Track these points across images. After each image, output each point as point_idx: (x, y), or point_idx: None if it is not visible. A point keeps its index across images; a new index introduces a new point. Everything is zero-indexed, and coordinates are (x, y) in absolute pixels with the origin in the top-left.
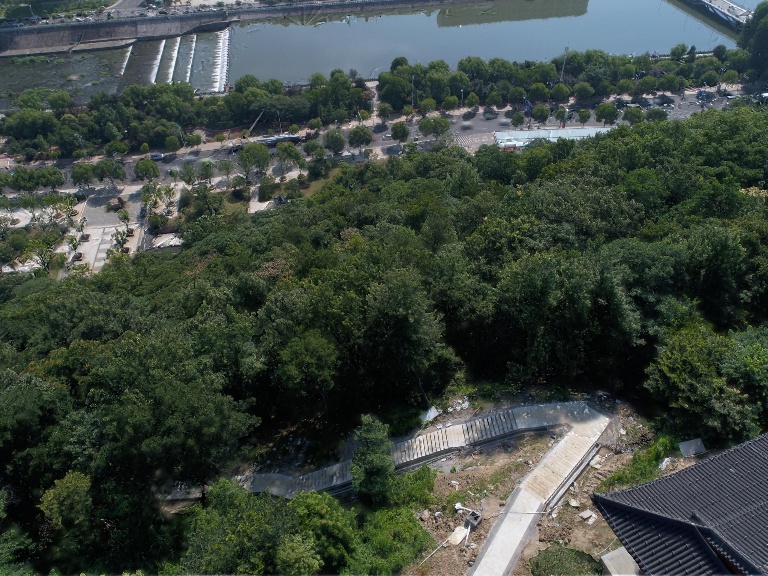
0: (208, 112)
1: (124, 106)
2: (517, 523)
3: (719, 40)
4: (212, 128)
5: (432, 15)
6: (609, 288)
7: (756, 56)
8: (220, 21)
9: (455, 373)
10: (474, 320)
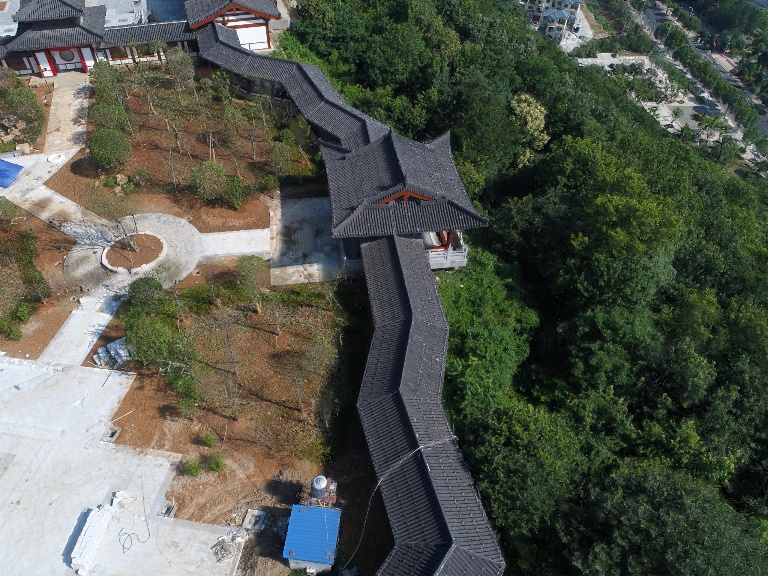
0: None
1: None
2: None
3: None
4: None
5: None
6: None
7: None
8: None
9: None
10: None
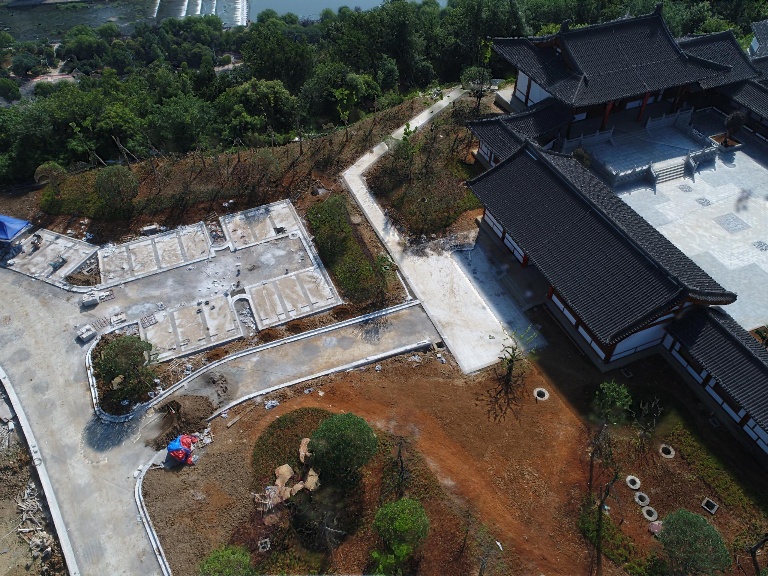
0: (236, 38)
1: (165, 32)
2: (459, 92)
3: None
4: (239, 53)
5: None
6: (515, 10)
7: None
8: None
9: (433, 79)
10: (444, 51)
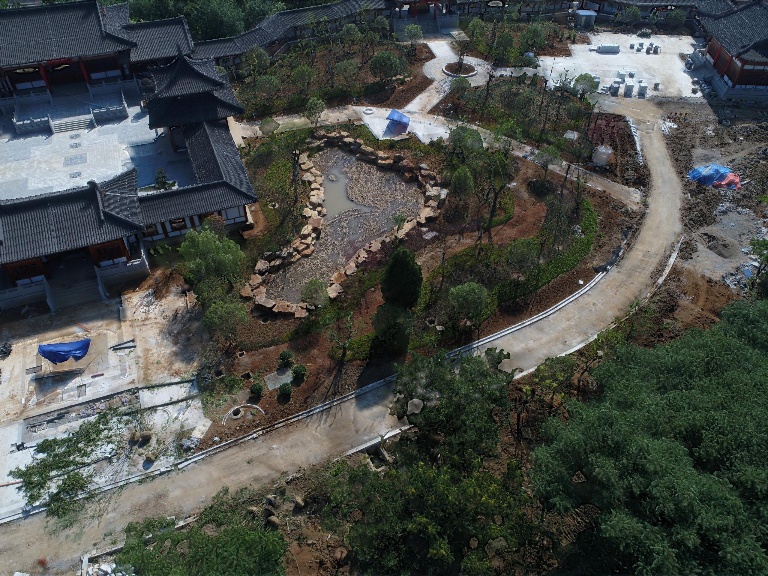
0: None
1: None
2: None
3: None
4: None
5: None
6: None
7: None
8: None
9: None
10: None
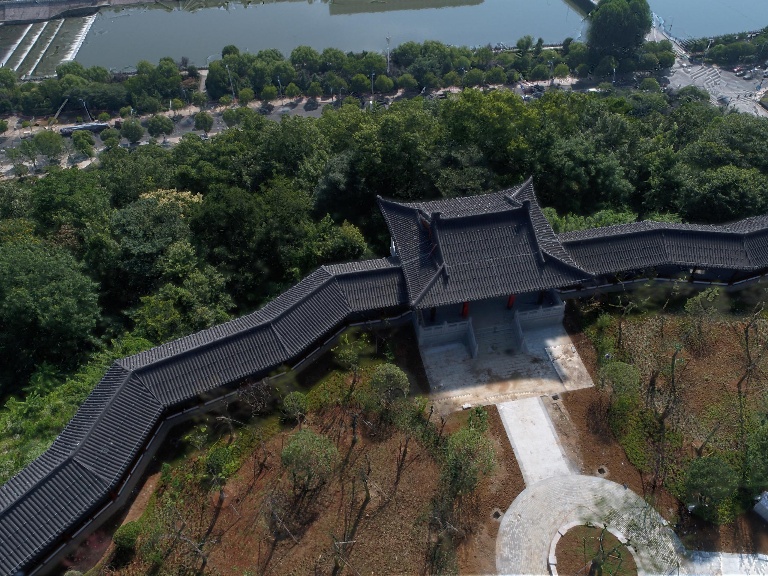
0: None
1: None
2: None
3: (567, 33)
4: (28, 115)
5: (314, 3)
6: None
7: (594, 50)
8: (90, 6)
9: None
10: None
